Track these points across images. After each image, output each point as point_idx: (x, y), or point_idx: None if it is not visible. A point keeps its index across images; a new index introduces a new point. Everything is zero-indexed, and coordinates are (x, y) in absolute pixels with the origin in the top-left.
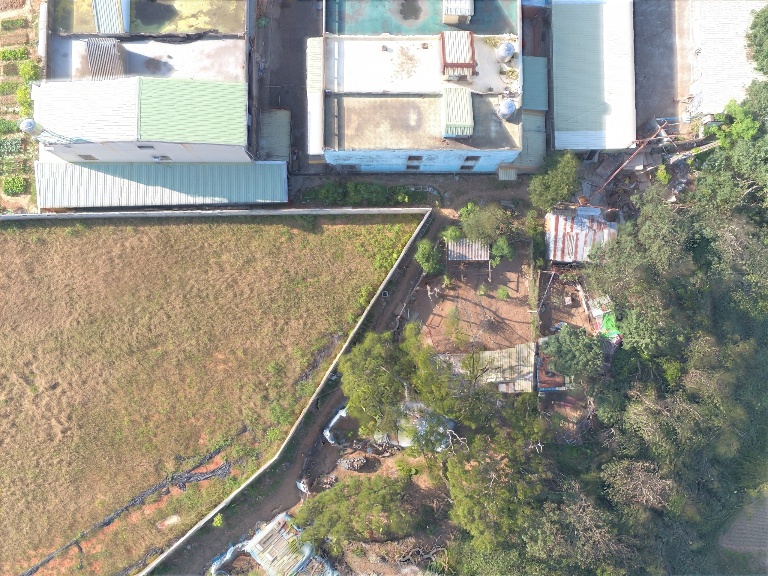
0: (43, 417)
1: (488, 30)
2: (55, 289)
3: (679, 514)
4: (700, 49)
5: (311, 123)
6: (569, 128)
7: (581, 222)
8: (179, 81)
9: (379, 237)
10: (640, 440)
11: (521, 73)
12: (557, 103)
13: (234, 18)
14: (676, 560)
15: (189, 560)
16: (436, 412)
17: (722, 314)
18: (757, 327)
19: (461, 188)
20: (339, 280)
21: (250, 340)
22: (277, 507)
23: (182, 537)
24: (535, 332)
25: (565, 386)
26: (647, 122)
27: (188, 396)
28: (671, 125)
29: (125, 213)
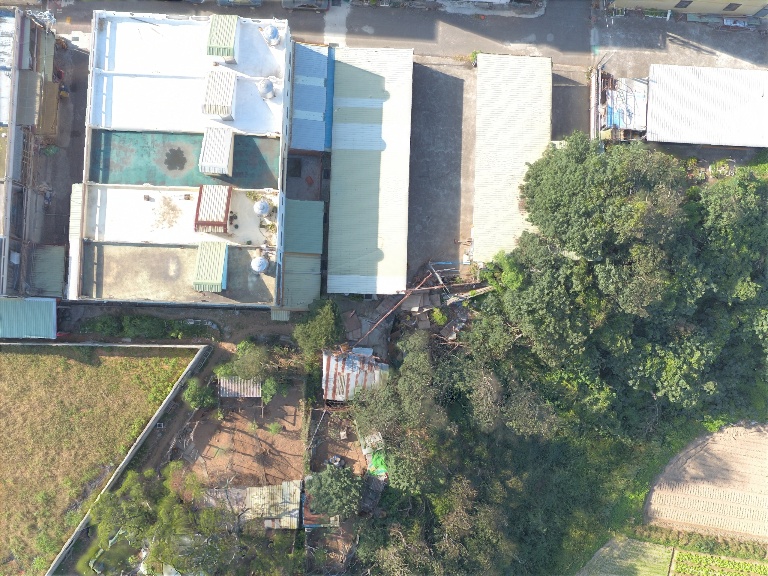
0: None
1: (250, 183)
2: None
3: None
4: None
5: (71, 268)
6: (342, 272)
7: (352, 363)
8: None
9: (156, 370)
10: None
11: (277, 229)
12: (331, 247)
13: None
14: None
15: None
16: None
17: (513, 440)
18: (553, 450)
19: (241, 322)
20: (113, 412)
21: (21, 469)
22: None
23: None
24: (306, 468)
25: (330, 523)
26: (426, 264)
27: None
28: (450, 267)
29: None
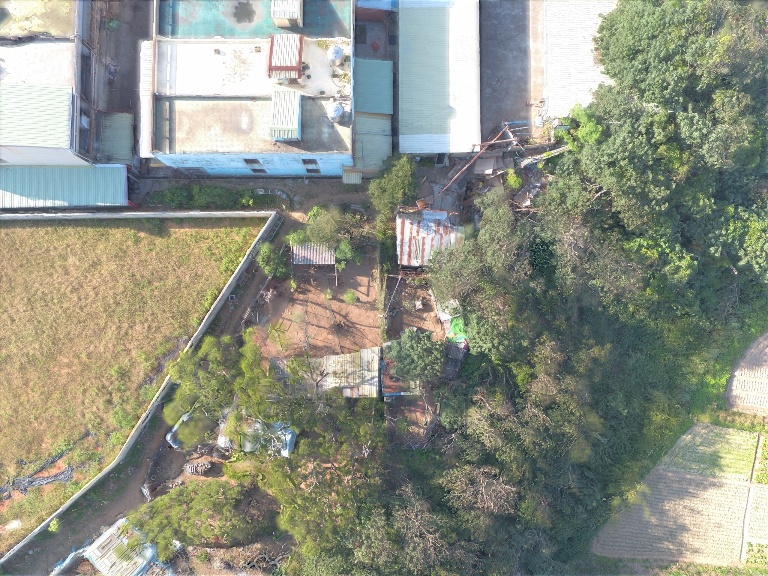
0: None
1: (321, 33)
2: None
3: (543, 521)
4: None
5: (143, 126)
6: (414, 132)
7: (427, 226)
8: (0, 84)
9: (226, 241)
10: (482, 446)
11: (351, 76)
12: (402, 107)
13: (67, 21)
14: (536, 568)
15: (31, 565)
16: None
17: (589, 319)
18: (629, 333)
19: (311, 192)
20: (185, 284)
21: (94, 344)
22: (122, 512)
23: (23, 542)
24: (382, 337)
25: None
26: (498, 126)
27: (31, 400)
28: (523, 129)
29: None
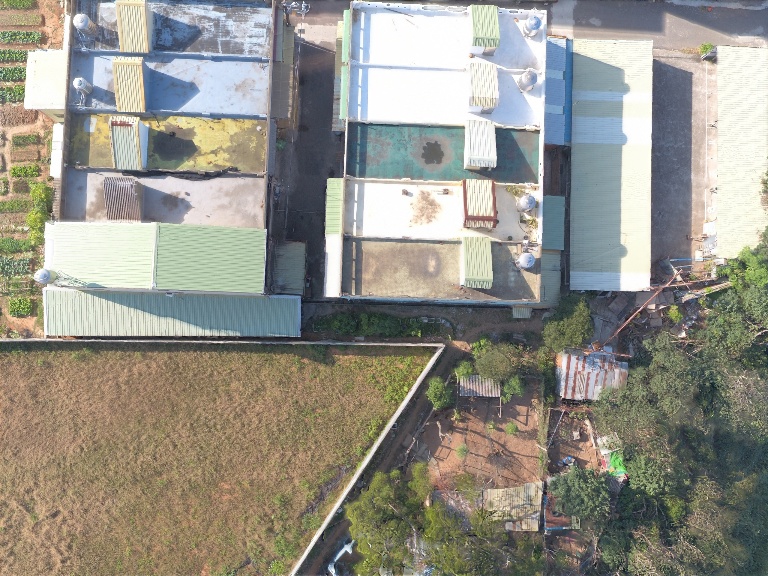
0: (42, 545)
1: (509, 177)
2: (59, 414)
3: None
4: (715, 189)
5: (328, 265)
6: (584, 269)
7: (593, 362)
8: (197, 227)
9: (390, 369)
10: None
11: (541, 224)
12: (573, 243)
13: (254, 156)
14: None
15: None
16: None
17: (725, 441)
18: (758, 450)
19: (474, 320)
20: (349, 412)
21: (257, 471)
22: None
23: None
24: (543, 469)
25: (572, 526)
26: (660, 260)
27: (192, 526)
28: (684, 264)
29: (134, 341)
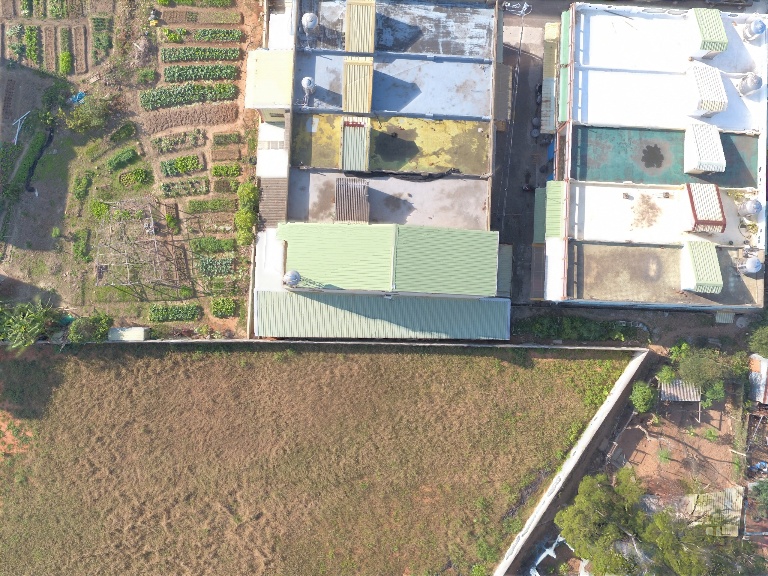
0: (246, 548)
1: (728, 182)
2: (261, 415)
3: None
4: None
5: (548, 268)
6: None
7: None
8: (434, 230)
9: (589, 372)
10: None
11: (764, 229)
12: None
13: (475, 158)
14: None
15: None
16: (662, 566)
17: None
18: None
19: (670, 325)
20: (549, 415)
21: (458, 474)
22: None
23: None
24: None
25: None
26: None
27: (393, 529)
28: None
29: (341, 343)
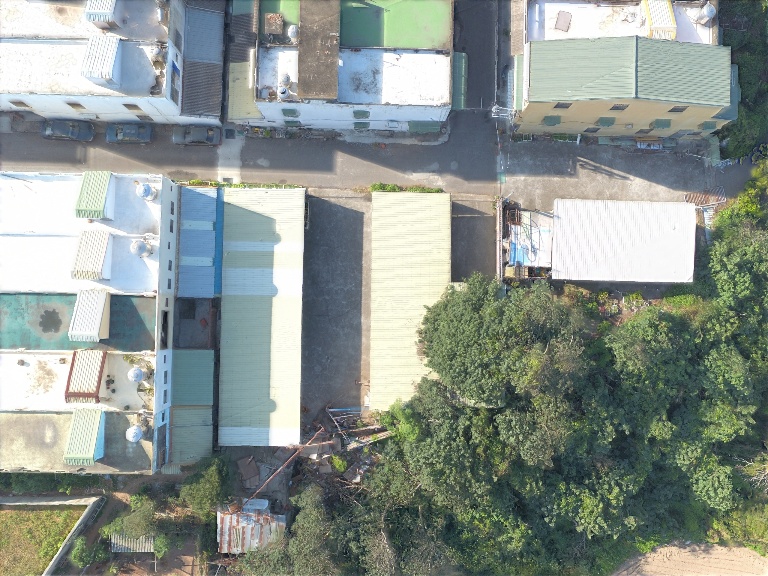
0: None
1: (128, 345)
2: None
3: None
4: None
5: None
6: (233, 424)
7: (247, 516)
8: None
9: (47, 523)
10: None
11: (154, 395)
12: (222, 398)
13: None
14: None
15: None
16: None
17: (430, 573)
18: None
19: None
20: (3, 568)
21: None
22: None
23: None
24: None
25: None
26: (325, 407)
27: None
28: None
29: None
